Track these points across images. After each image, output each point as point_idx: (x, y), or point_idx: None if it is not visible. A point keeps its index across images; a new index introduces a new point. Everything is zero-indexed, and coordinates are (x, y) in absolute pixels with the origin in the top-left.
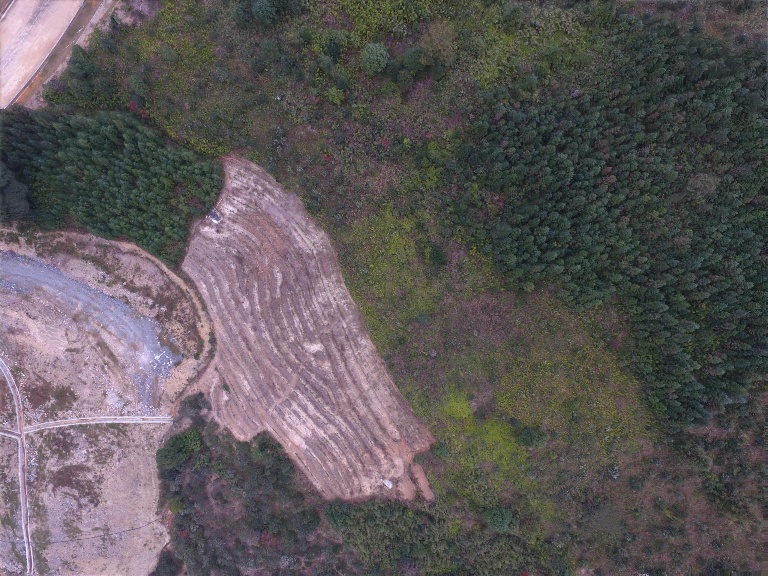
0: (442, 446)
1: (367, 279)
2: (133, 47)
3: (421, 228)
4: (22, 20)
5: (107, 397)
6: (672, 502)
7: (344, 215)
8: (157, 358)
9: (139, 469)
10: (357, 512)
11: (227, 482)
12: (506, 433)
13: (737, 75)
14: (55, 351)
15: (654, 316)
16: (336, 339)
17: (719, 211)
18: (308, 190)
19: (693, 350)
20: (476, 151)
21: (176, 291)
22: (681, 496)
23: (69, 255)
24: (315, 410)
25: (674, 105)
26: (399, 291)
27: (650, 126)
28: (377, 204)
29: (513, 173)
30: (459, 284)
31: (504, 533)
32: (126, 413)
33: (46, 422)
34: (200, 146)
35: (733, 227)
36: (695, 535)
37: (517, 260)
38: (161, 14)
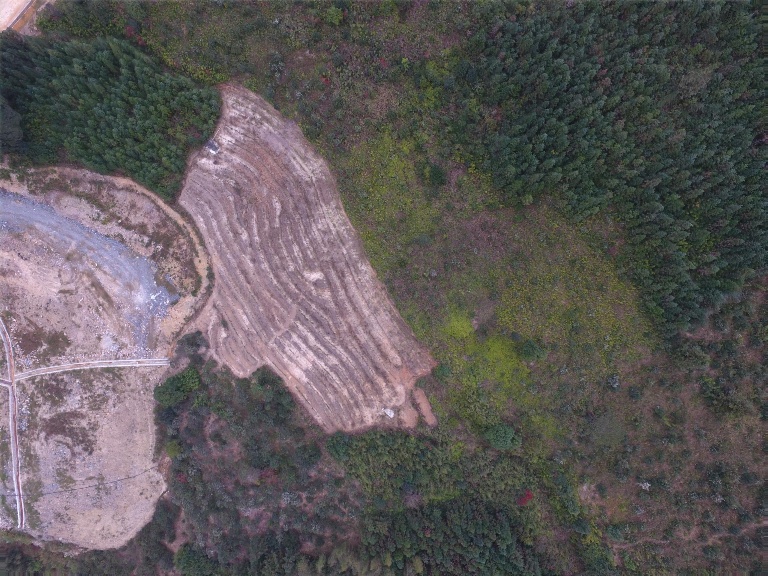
0: (444, 367)
1: (367, 203)
2: None
3: (420, 149)
4: None
5: (101, 341)
6: (670, 409)
7: (343, 140)
8: (153, 298)
9: (135, 415)
10: (359, 442)
11: (226, 422)
12: (507, 349)
13: None
14: (48, 293)
15: (650, 217)
16: (336, 266)
17: (710, 108)
18: (307, 116)
19: (688, 250)
20: (473, 68)
21: (173, 227)
22: (679, 402)
23: (62, 192)
24: (315, 341)
25: (665, 5)
26: (399, 214)
27: (642, 29)
28: (376, 127)
29: (511, 84)
30: (458, 203)
31: (506, 454)
32: (121, 356)
33: (38, 368)
34: (198, 73)
35: (724, 123)
36: (693, 441)
37: (516, 171)
38: None
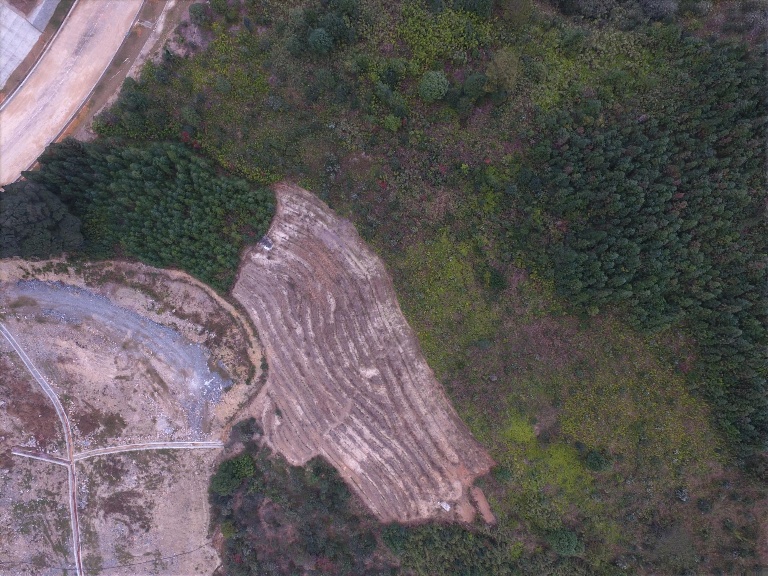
0: (504, 470)
1: (424, 304)
2: (187, 79)
3: (479, 252)
4: (67, 51)
5: (156, 423)
6: (742, 523)
7: (399, 240)
8: (207, 384)
9: (190, 494)
10: (416, 535)
11: (280, 506)
12: (570, 457)
13: None
14: (105, 379)
15: (727, 341)
16: (392, 364)
17: None
18: (362, 216)
19: (767, 374)
20: (537, 176)
21: (226, 317)
22: (752, 518)
23: (118, 284)
24: (370, 434)
25: (749, 130)
26: (457, 316)
27: (722, 151)
28: (433, 229)
29: (578, 199)
30: (519, 308)
31: (567, 555)
32: (176, 439)
33: (96, 449)
34: (252, 174)
35: None
36: (766, 556)
37: (583, 285)
38: (215, 45)
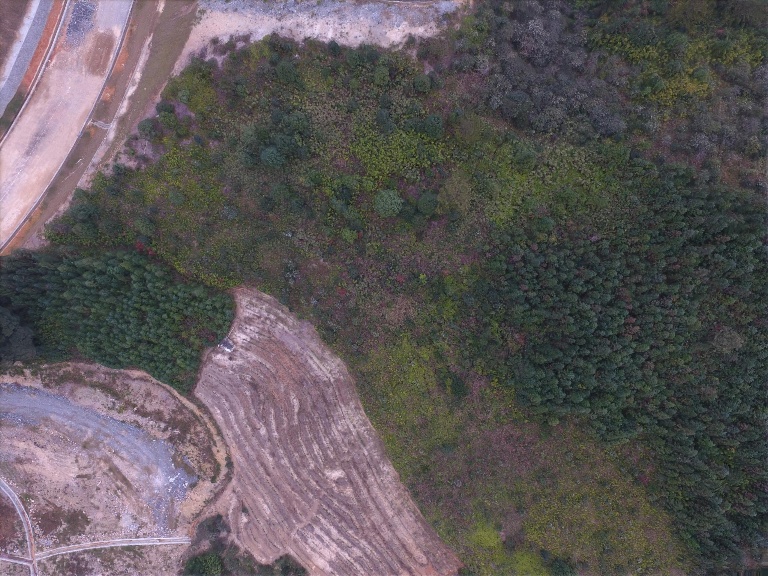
0: (472, 575)
1: (387, 408)
2: (138, 192)
3: (440, 358)
4: (18, 151)
5: (121, 519)
6: None
7: (361, 344)
8: (172, 481)
9: None
10: None
11: None
12: (536, 563)
13: (757, 234)
14: (65, 478)
15: (683, 460)
16: (358, 466)
17: (745, 363)
18: (323, 320)
19: (723, 491)
20: (494, 287)
21: (189, 415)
22: None
23: (77, 384)
24: (338, 534)
25: (695, 260)
26: (420, 420)
27: (671, 276)
28: (394, 334)
29: (534, 316)
30: (482, 414)
31: None
32: (142, 535)
33: (58, 547)
34: (210, 280)
35: (759, 378)
36: None
37: (542, 400)
38: (166, 158)
